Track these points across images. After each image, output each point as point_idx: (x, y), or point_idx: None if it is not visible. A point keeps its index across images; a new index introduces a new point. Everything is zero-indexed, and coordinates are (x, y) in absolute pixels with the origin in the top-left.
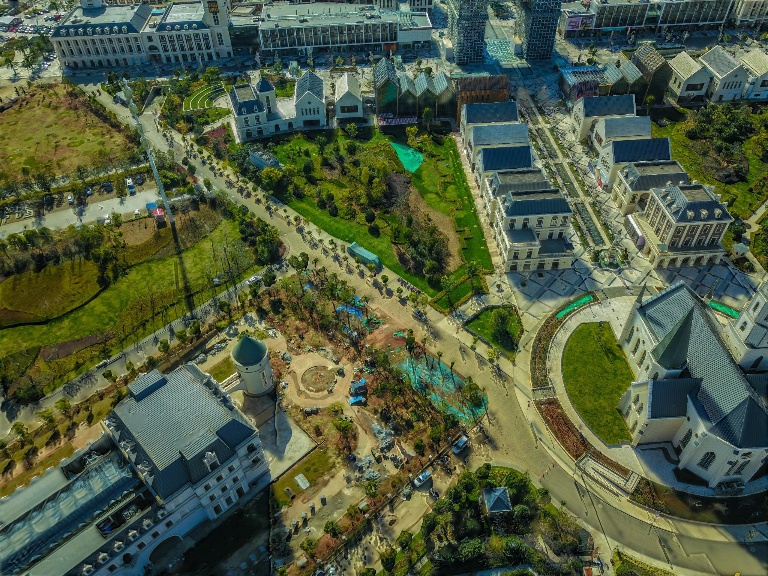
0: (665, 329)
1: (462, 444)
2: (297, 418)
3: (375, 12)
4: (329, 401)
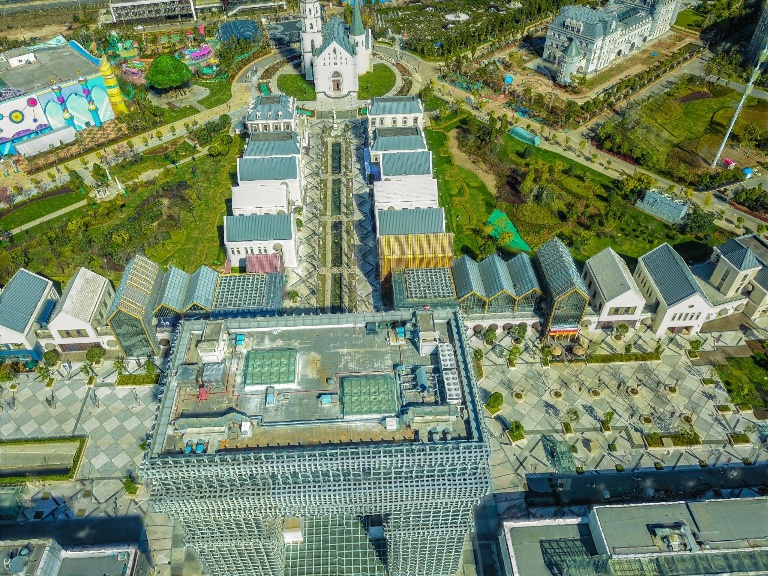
0: (348, 47)
1: (452, 63)
2: None
3: (680, 574)
4: (523, 78)
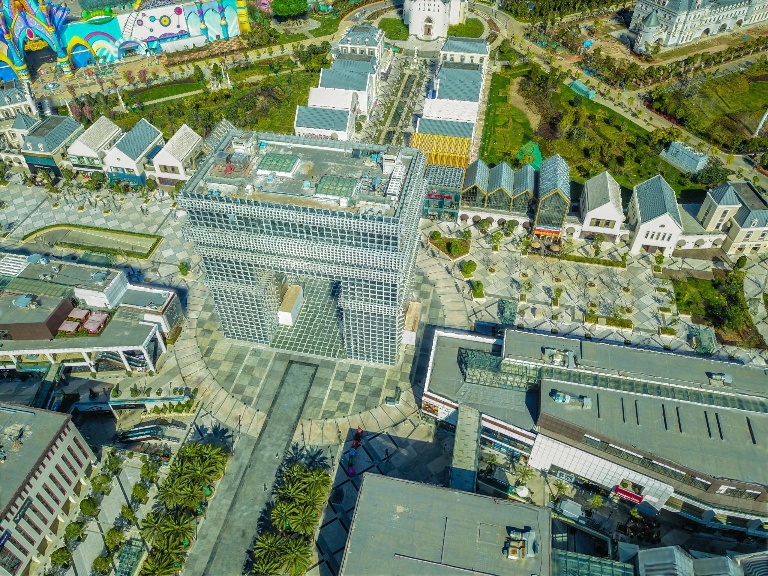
0: None
1: None
2: (618, 41)
3: (552, 378)
4: None
